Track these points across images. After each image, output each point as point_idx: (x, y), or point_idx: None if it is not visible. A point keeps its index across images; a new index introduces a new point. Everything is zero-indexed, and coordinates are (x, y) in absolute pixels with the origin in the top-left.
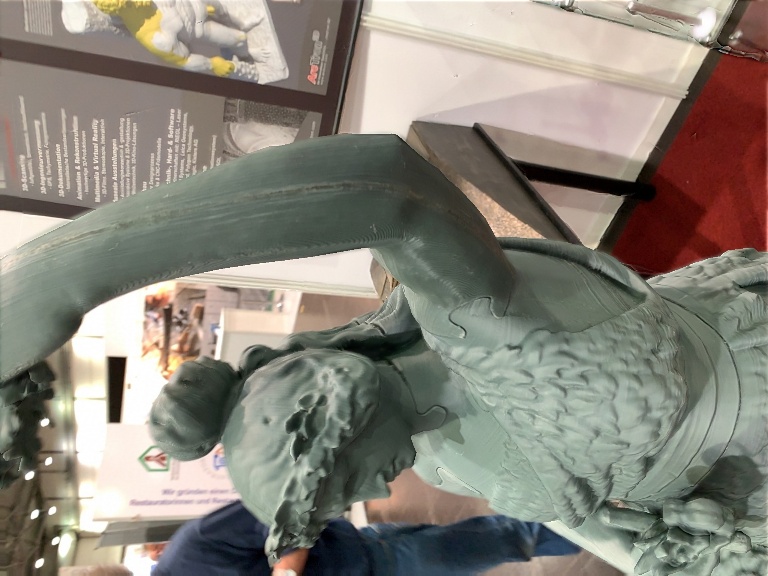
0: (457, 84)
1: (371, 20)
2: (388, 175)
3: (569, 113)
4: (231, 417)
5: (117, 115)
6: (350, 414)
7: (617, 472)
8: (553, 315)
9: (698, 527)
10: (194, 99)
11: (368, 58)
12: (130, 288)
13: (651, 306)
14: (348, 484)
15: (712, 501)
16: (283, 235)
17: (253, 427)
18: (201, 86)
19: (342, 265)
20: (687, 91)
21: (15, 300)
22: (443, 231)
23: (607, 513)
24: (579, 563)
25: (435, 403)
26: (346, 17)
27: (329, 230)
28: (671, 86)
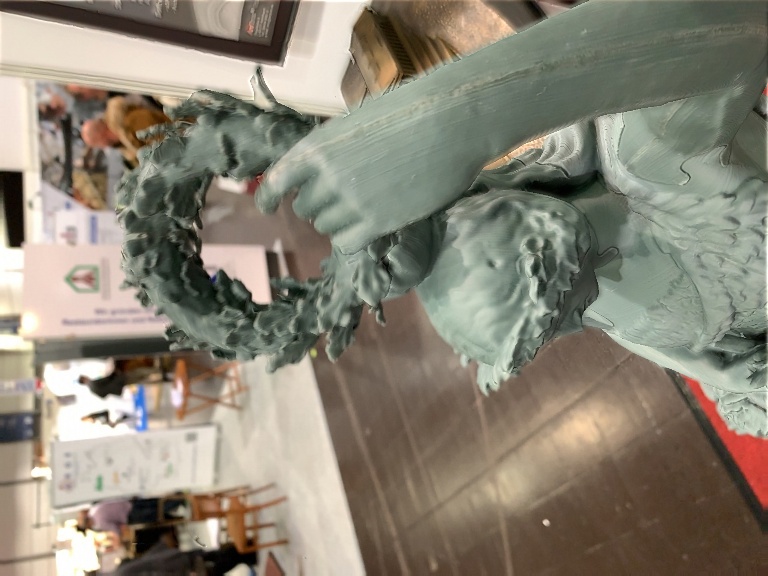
0: None
1: None
2: None
3: None
4: (440, 259)
5: None
6: None
7: None
8: (757, 163)
9: None
10: None
11: None
12: None
13: None
14: None
15: None
16: (681, 83)
17: (478, 270)
18: None
19: (310, 81)
20: None
21: (435, 149)
22: (762, 79)
23: None
24: None
25: (612, 245)
26: None
27: (712, 78)
28: None
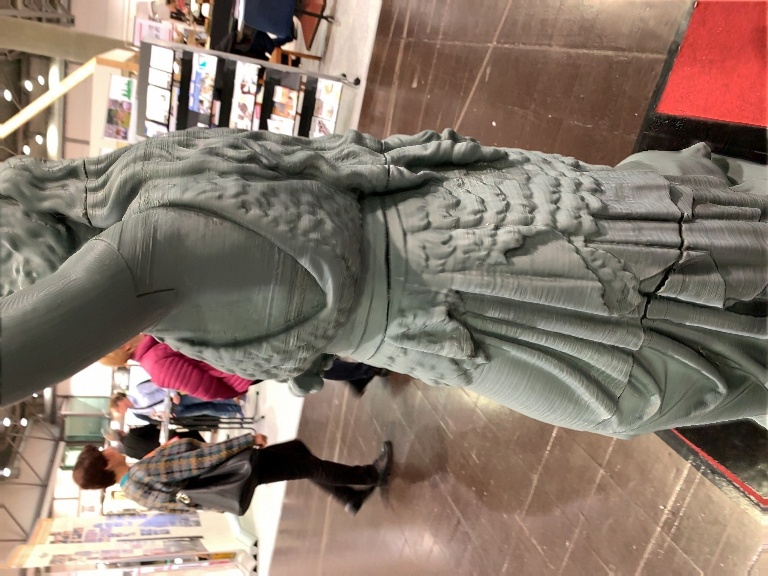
0: None
1: None
2: None
3: None
4: None
5: None
6: None
7: None
8: (206, 325)
9: None
10: None
11: None
12: None
13: (305, 333)
14: None
15: (303, 390)
16: None
17: None
18: None
19: None
20: None
21: None
22: None
23: None
24: None
25: None
26: None
27: None
28: None
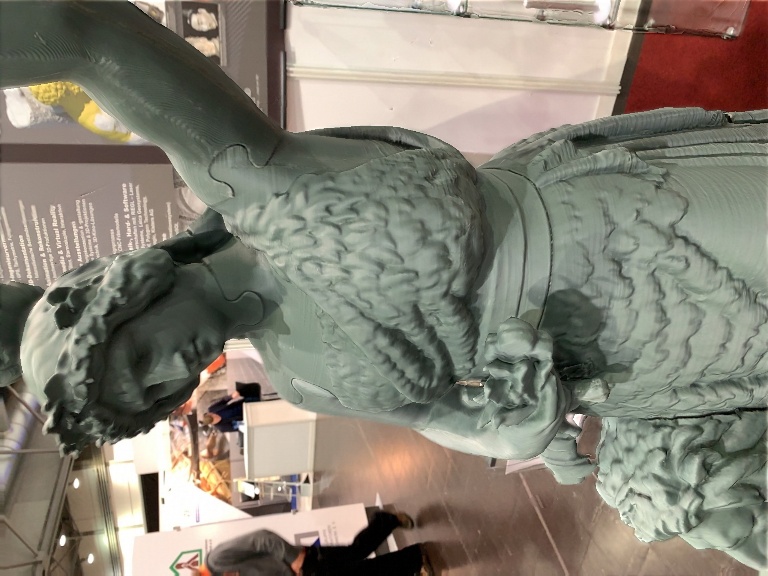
0: (394, 117)
1: (298, 71)
2: None
3: (509, 126)
4: None
5: (72, 198)
6: (122, 283)
7: (433, 321)
8: (327, 166)
9: (514, 352)
10: (143, 171)
11: (302, 106)
12: None
13: (434, 149)
14: (141, 364)
15: (519, 319)
16: None
17: (35, 318)
18: (148, 158)
19: None
20: (619, 86)
21: None
22: (137, 53)
23: (464, 391)
24: None
25: (245, 289)
26: (273, 71)
27: None
28: (603, 84)
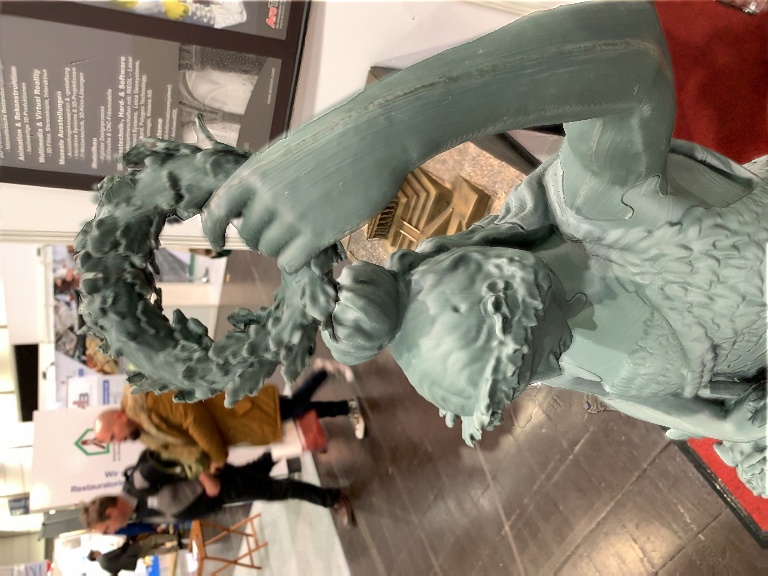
0: (414, 27)
1: None
2: (651, 36)
3: None
4: (408, 313)
5: (61, 64)
6: (539, 295)
7: (741, 338)
8: (697, 195)
9: None
10: (145, 46)
11: None
12: (452, 145)
13: None
14: None
15: None
16: (579, 91)
17: (444, 317)
18: (153, 31)
19: None
20: None
21: (357, 157)
22: (666, 100)
23: (707, 385)
24: (541, 485)
25: (578, 291)
26: None
27: (609, 89)
28: None
